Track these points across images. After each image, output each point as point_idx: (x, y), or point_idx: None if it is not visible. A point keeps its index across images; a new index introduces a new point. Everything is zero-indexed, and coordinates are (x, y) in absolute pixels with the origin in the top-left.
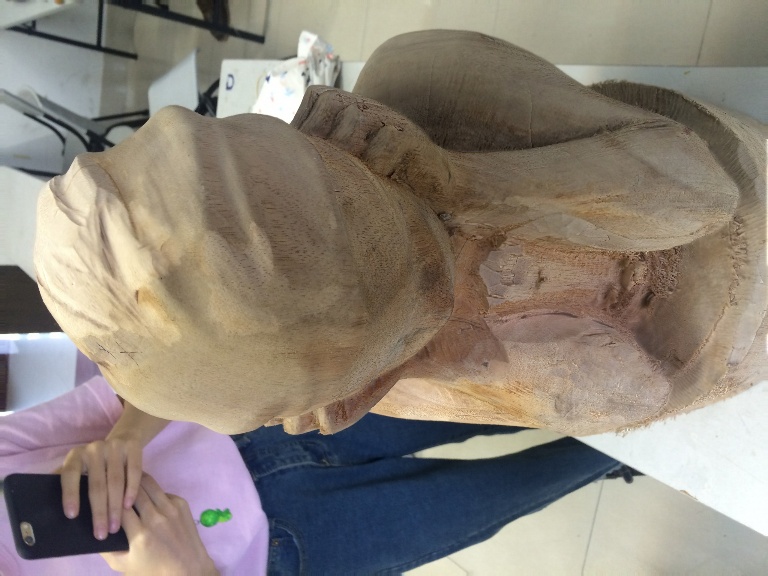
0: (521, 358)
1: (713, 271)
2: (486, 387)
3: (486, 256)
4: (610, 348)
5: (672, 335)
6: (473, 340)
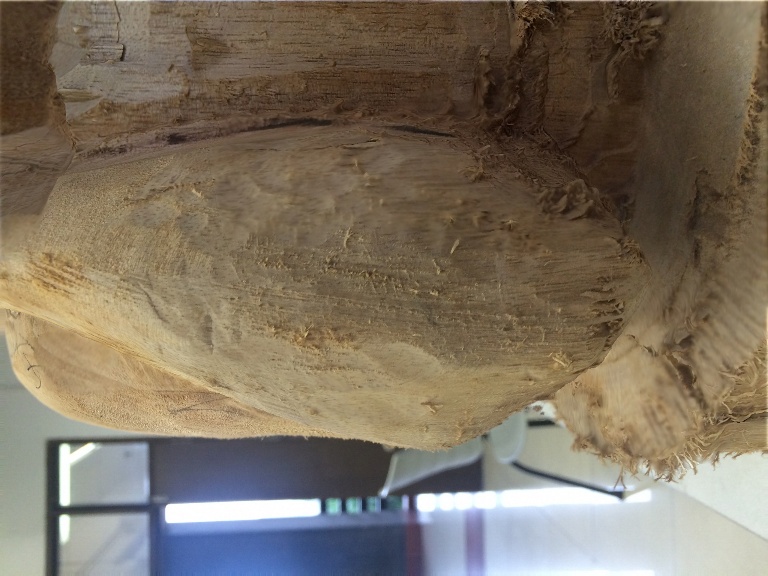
0: (70, 200)
1: None
2: (3, 281)
3: (56, 21)
4: (345, 149)
5: (691, 134)
6: (8, 188)
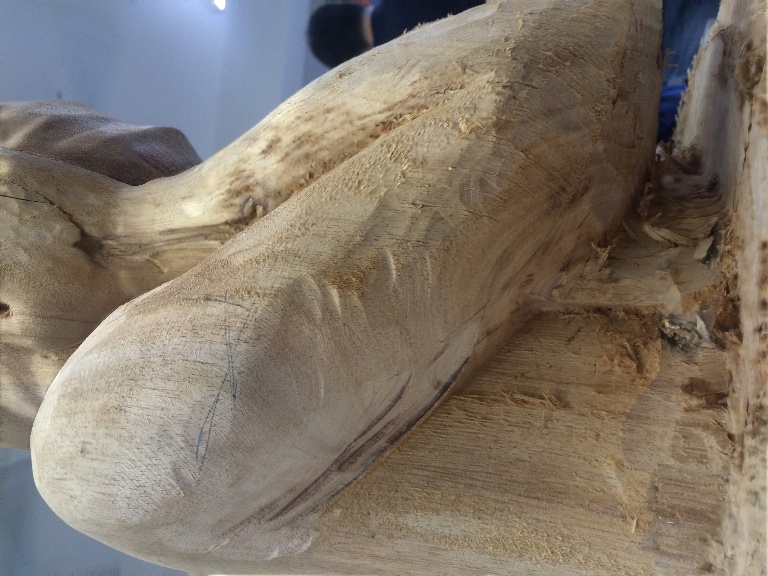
0: None
1: (693, 109)
2: None
3: None
4: None
5: None
6: None
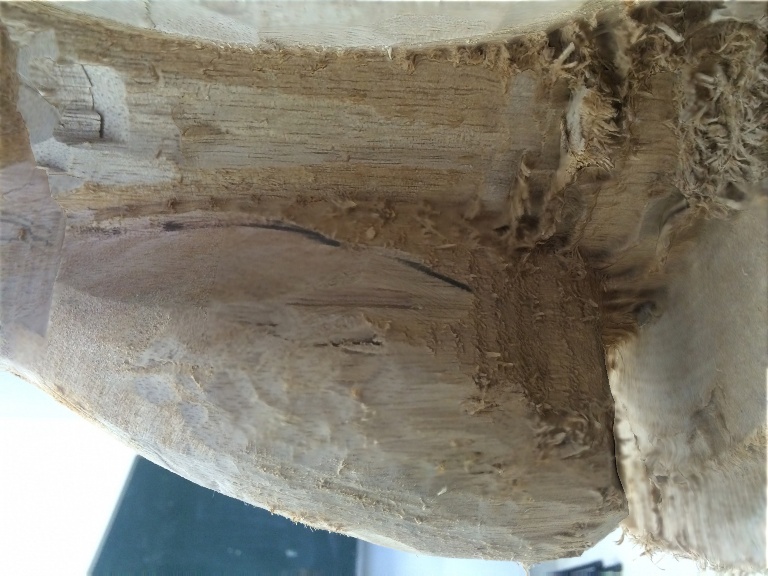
0: (71, 333)
1: None
2: None
3: (16, 63)
4: (346, 355)
5: (725, 344)
6: (6, 267)
